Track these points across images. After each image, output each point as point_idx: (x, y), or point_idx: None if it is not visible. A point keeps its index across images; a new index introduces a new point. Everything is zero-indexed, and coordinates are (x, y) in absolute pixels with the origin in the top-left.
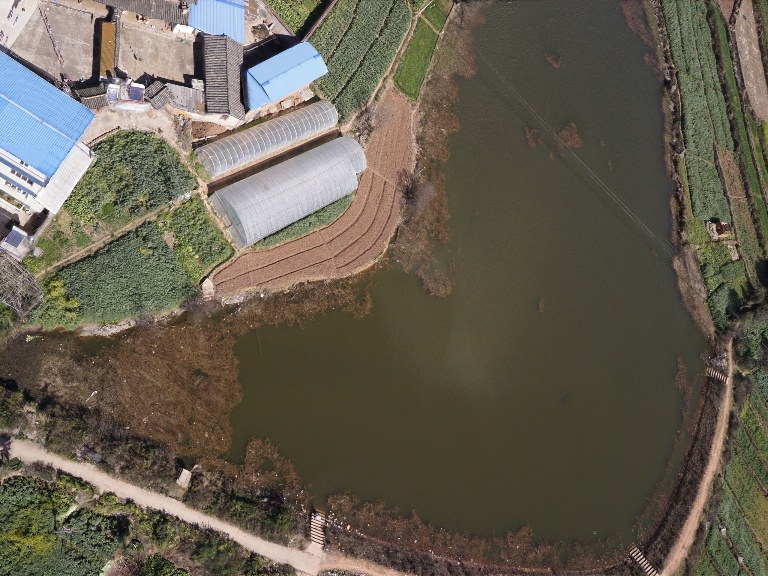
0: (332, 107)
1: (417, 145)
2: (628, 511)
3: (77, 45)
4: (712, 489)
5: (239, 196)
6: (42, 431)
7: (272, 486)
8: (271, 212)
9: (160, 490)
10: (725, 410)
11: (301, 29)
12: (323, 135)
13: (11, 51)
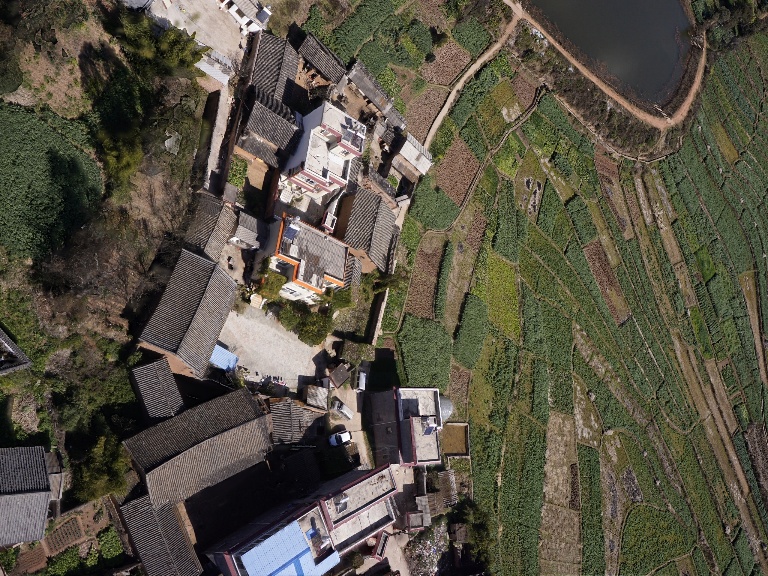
0: None
1: None
2: (652, 87)
3: None
4: (696, 97)
5: None
6: None
7: None
8: None
9: None
10: (702, 63)
11: None
12: None
13: None
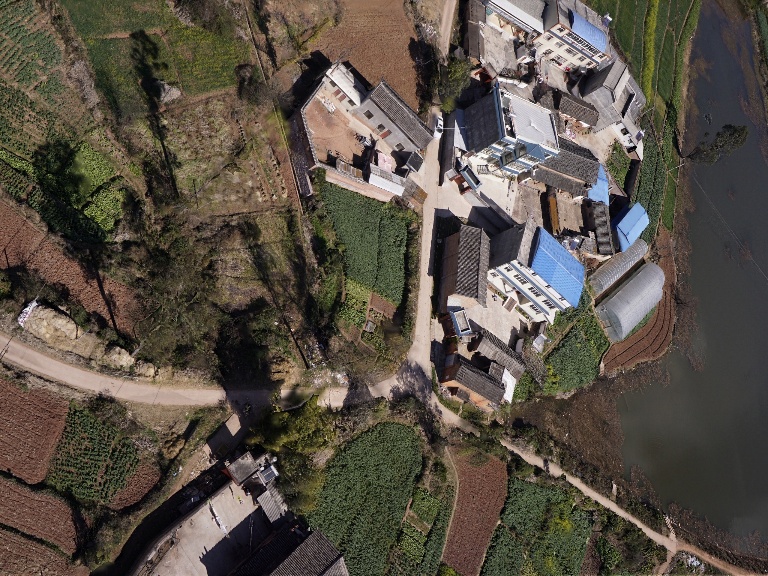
0: (645, 244)
1: (675, 264)
2: None
3: (535, 212)
4: None
5: (618, 309)
6: (558, 458)
7: (644, 496)
8: (632, 318)
9: (607, 496)
10: None
11: (624, 190)
12: (637, 262)
13: (512, 219)
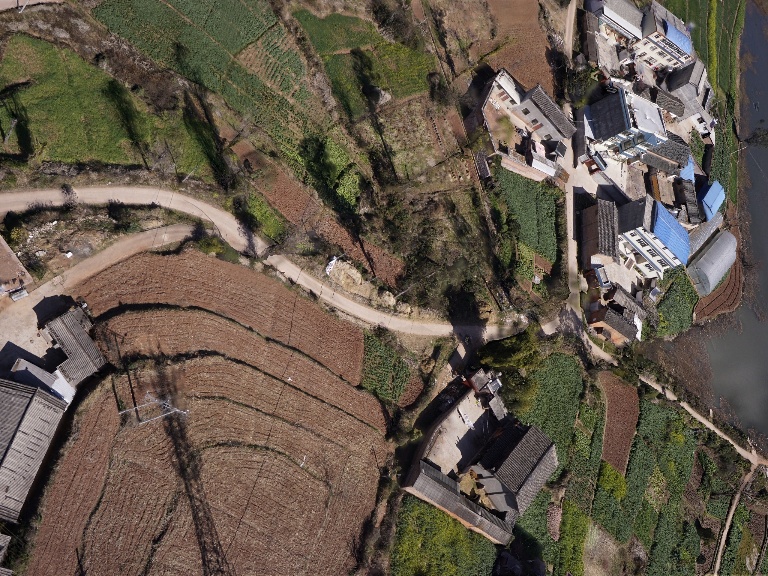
0: (721, 215)
1: (740, 233)
2: None
3: (641, 189)
4: None
5: (706, 268)
6: (671, 386)
7: (731, 421)
8: (716, 277)
9: (706, 418)
10: None
11: None
12: None
13: (626, 194)
